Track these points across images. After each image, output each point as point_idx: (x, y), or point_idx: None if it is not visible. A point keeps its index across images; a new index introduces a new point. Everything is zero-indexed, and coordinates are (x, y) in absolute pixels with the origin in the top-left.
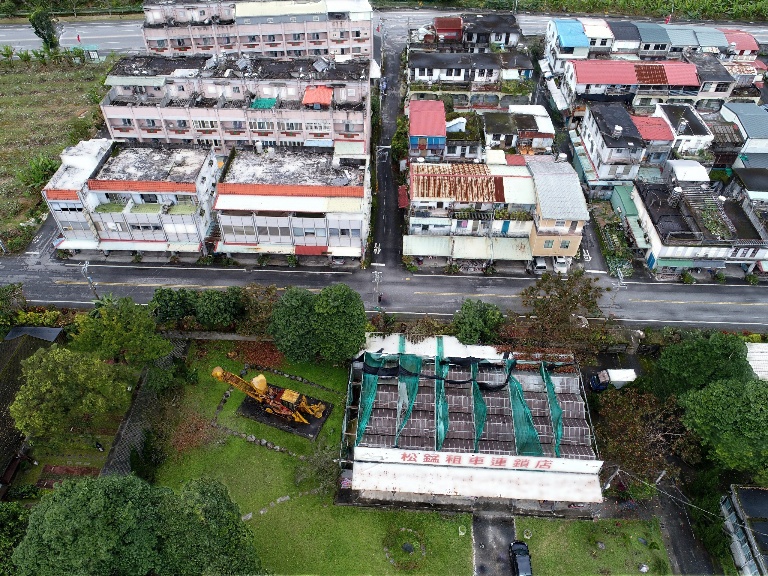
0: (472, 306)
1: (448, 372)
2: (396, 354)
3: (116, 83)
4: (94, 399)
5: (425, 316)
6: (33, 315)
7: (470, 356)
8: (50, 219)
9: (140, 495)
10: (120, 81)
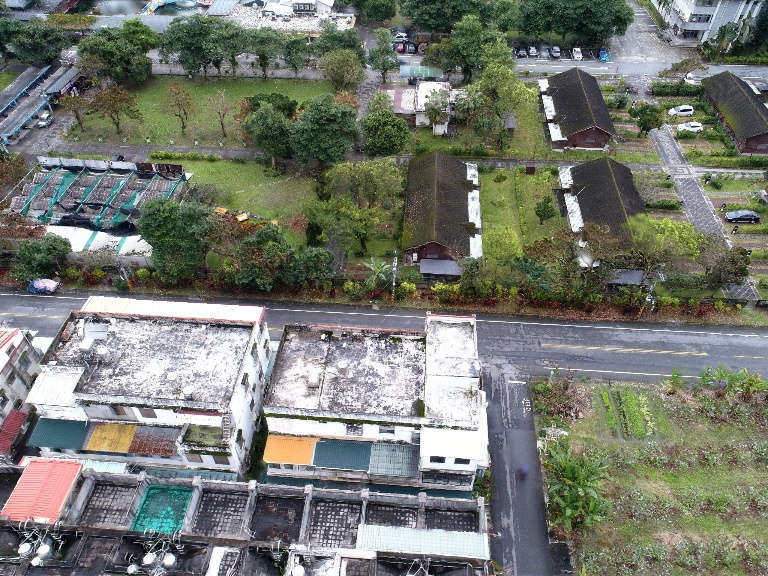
0: (42, 242)
1: (96, 216)
2: (130, 222)
3: (462, 538)
4: (342, 164)
5: (86, 268)
6: (455, 286)
7: (72, 217)
8: (530, 441)
9: (302, 130)
10: (456, 544)
